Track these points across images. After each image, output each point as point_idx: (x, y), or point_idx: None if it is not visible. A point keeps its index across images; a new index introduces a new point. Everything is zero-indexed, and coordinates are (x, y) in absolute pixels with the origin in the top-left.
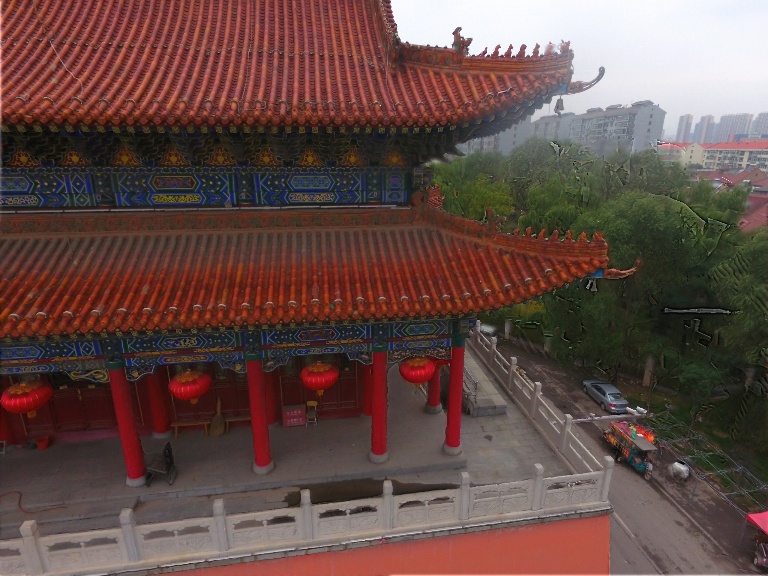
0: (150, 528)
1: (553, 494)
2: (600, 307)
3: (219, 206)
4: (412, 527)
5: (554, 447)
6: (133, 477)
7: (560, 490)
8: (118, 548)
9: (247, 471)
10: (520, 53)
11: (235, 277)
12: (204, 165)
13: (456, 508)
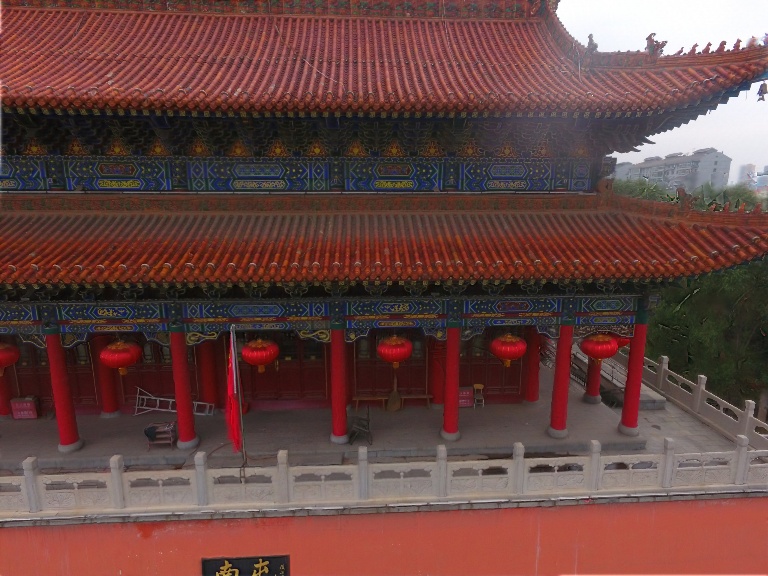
0: (381, 467)
1: (756, 469)
2: (711, 334)
3: (430, 190)
4: (616, 490)
5: (732, 436)
6: (339, 434)
7: (763, 465)
8: (352, 484)
9: (435, 438)
10: (720, 48)
11: (457, 245)
12: (419, 156)
13: (659, 475)
